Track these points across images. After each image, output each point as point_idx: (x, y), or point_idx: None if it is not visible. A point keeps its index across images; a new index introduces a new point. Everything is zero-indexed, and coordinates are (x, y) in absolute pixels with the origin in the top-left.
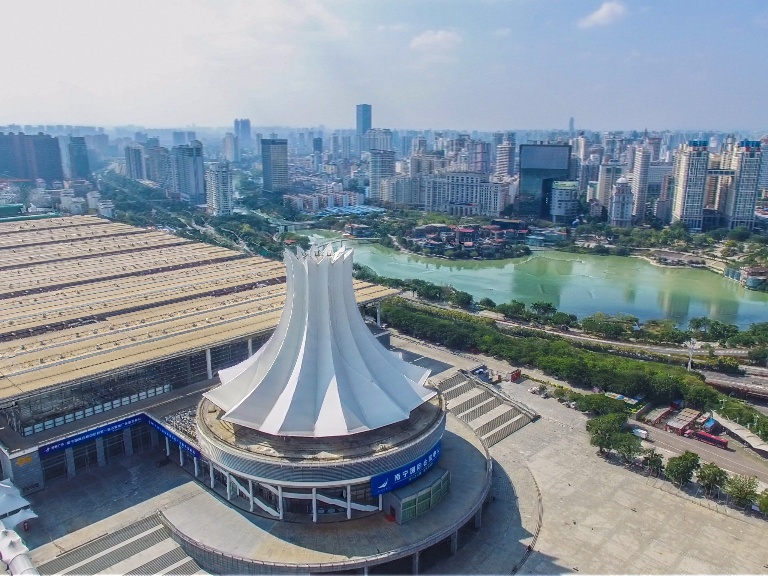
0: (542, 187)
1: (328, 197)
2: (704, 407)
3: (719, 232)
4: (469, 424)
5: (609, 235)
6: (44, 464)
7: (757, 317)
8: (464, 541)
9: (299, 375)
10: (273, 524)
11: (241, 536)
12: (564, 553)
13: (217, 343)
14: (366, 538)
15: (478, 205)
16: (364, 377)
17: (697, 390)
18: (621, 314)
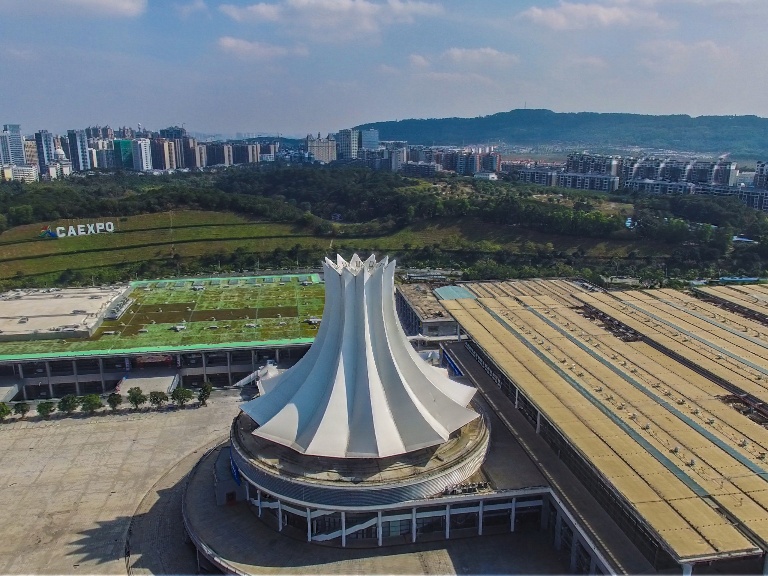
0: None
1: None
2: None
3: None
4: None
5: None
6: None
7: None
8: None
9: None
10: None
11: None
12: (94, 572)
13: None
14: None
15: None
16: None
17: None
18: None
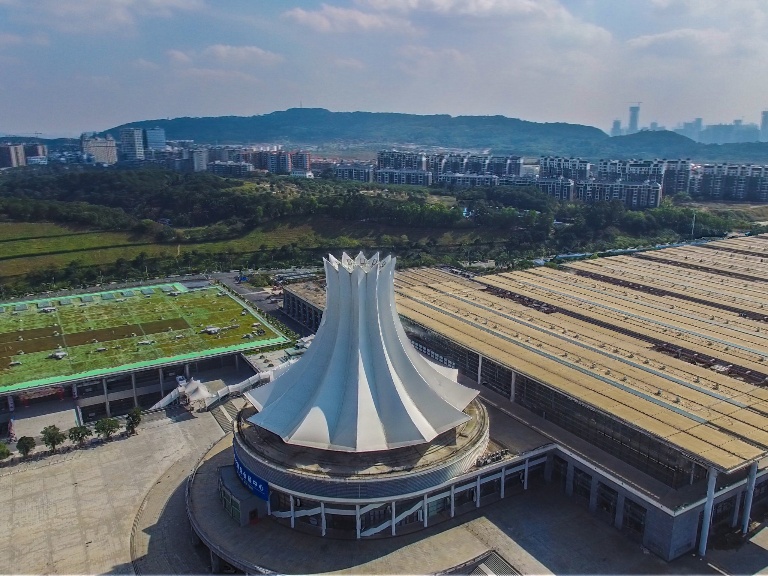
0: None
1: None
2: None
3: None
4: None
5: None
6: None
7: None
8: (205, 556)
9: None
10: None
11: None
12: None
13: None
14: None
15: None
16: None
17: None
18: None
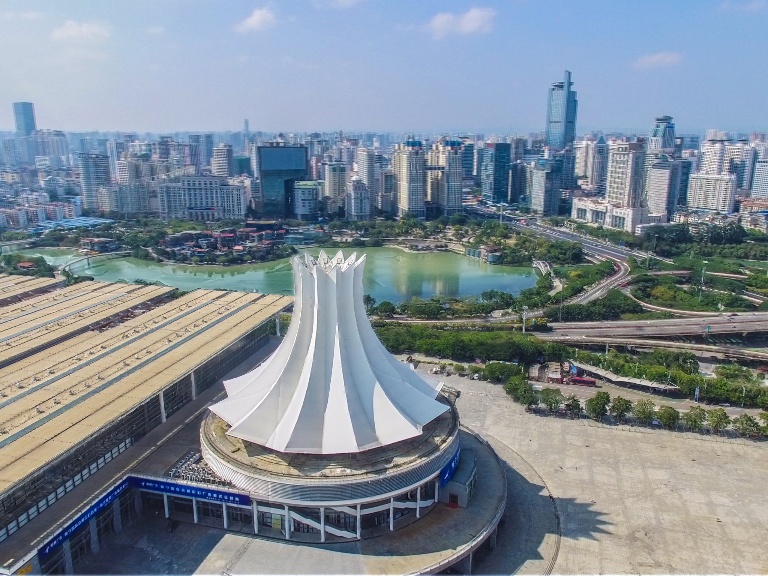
0: (284, 187)
1: (37, 210)
2: (561, 358)
3: (443, 219)
4: None
5: (358, 229)
6: (44, 569)
7: (514, 285)
8: None
9: (345, 388)
10: (357, 546)
11: (340, 567)
12: (576, 493)
13: (180, 378)
14: (451, 528)
15: (220, 209)
16: (395, 378)
17: (552, 346)
18: (434, 296)
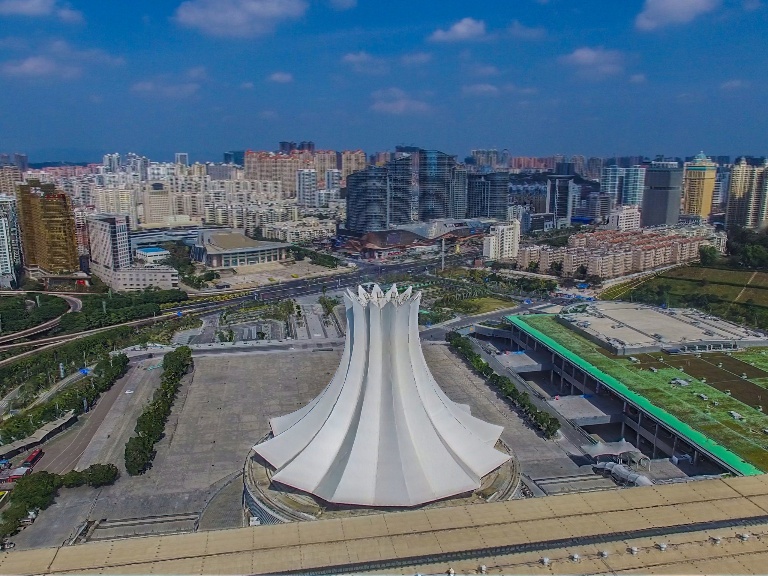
0: None
1: None
2: None
3: None
4: (179, 528)
5: None
6: None
7: None
8: None
9: None
10: None
11: None
12: None
13: None
14: None
15: None
16: None
17: None
18: None
